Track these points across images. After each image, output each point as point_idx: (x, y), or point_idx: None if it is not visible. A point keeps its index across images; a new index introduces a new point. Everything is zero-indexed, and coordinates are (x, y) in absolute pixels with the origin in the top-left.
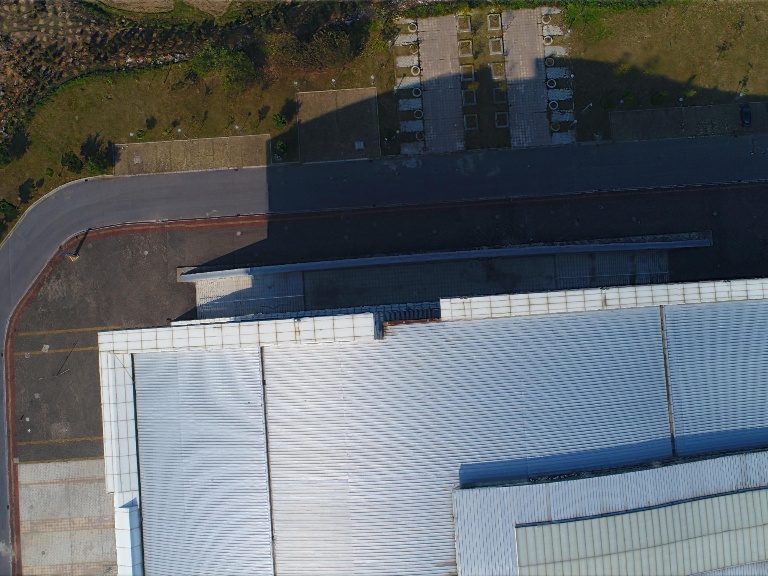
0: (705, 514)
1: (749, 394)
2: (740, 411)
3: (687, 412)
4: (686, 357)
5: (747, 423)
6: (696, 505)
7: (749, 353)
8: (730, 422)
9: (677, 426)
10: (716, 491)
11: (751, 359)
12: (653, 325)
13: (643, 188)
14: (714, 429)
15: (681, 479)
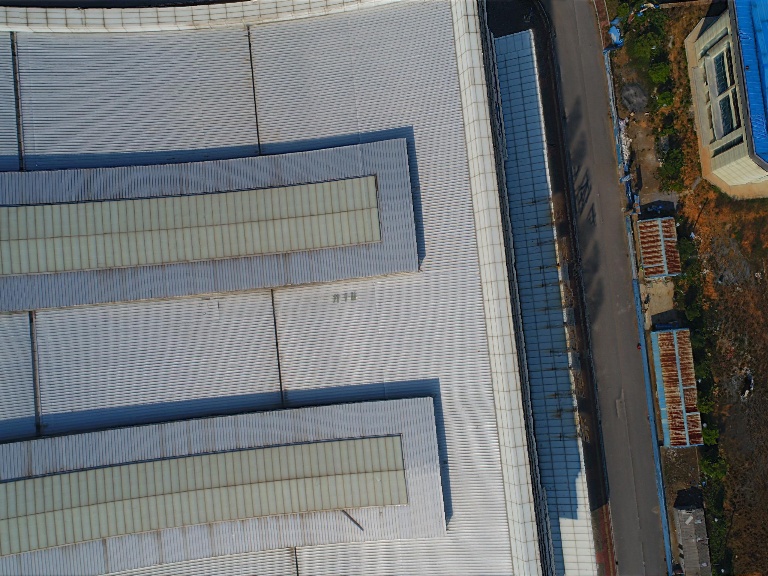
0: (33, 220)
1: (115, 121)
2: (104, 136)
3: (39, 133)
4: (41, 82)
5: (112, 148)
6: (23, 210)
7: (117, 83)
8: (92, 146)
9: (27, 145)
10: (51, 200)
11: (119, 88)
12: (1, 49)
13: (191, 2)
14: (73, 151)
15: (7, 186)
